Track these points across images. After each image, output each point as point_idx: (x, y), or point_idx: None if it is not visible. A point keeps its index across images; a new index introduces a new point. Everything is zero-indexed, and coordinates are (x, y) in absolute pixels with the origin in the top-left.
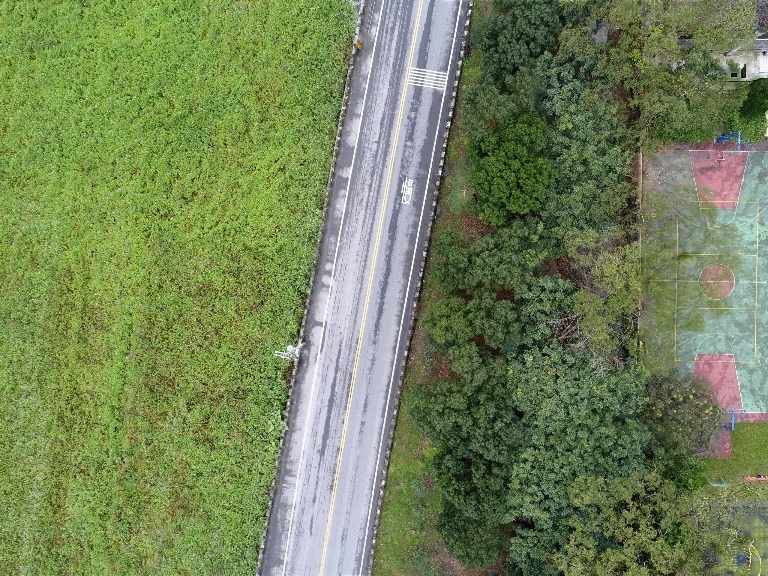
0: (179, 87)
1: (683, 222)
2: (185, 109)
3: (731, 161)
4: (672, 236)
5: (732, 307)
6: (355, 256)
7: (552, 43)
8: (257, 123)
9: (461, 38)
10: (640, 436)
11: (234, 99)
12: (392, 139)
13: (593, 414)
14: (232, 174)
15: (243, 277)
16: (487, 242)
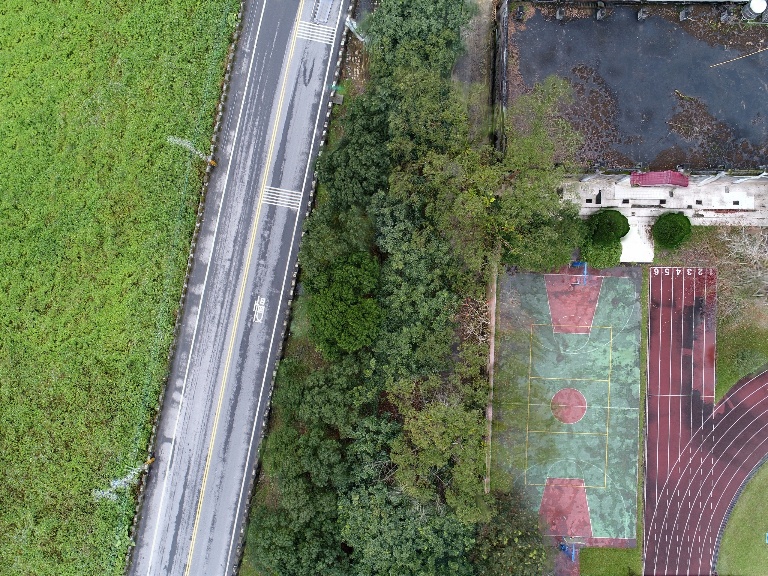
0: (34, 199)
1: (536, 345)
2: (39, 222)
3: (585, 286)
4: (525, 359)
5: (583, 432)
6: (206, 373)
7: (384, 183)
8: (110, 238)
9: (316, 158)
10: None
11: (89, 213)
12: (245, 257)
13: (417, 555)
14: (85, 288)
15: (94, 391)
16: (317, 378)
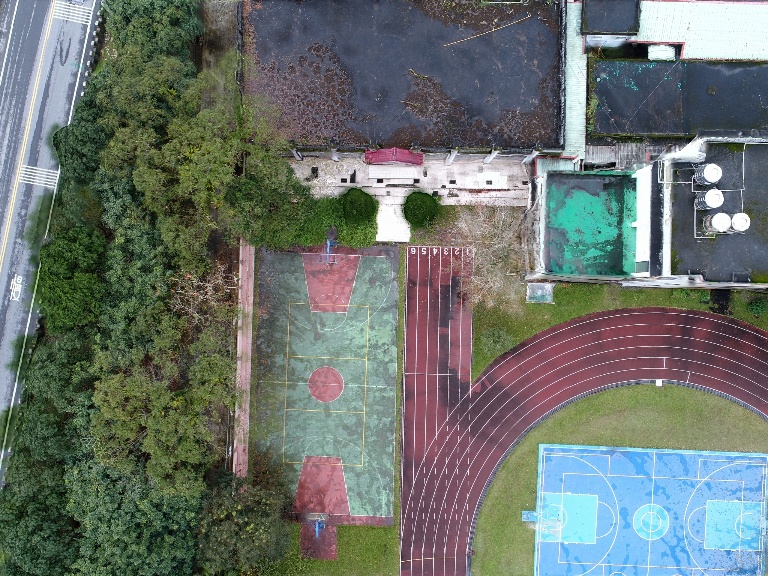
0: None
1: (294, 324)
2: None
3: (343, 265)
4: (283, 338)
5: (340, 410)
6: None
7: None
8: None
9: None
10: (172, 554)
11: None
12: (2, 236)
13: (134, 529)
14: None
15: None
16: (41, 353)
